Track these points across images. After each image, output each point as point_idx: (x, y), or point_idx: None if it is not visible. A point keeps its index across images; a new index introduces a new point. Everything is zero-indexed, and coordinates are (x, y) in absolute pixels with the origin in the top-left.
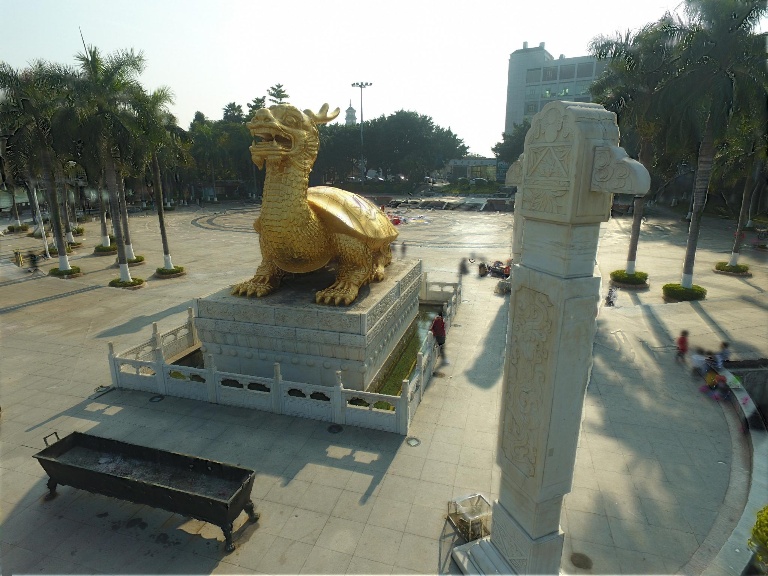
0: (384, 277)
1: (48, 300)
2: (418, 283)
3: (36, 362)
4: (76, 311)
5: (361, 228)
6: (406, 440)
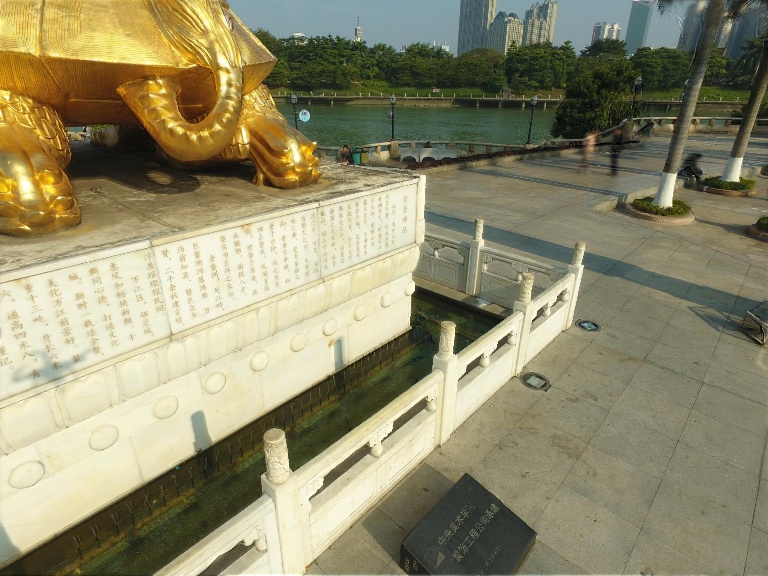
0: None
1: (542, 182)
2: None
3: None
4: (480, 190)
5: None
6: None
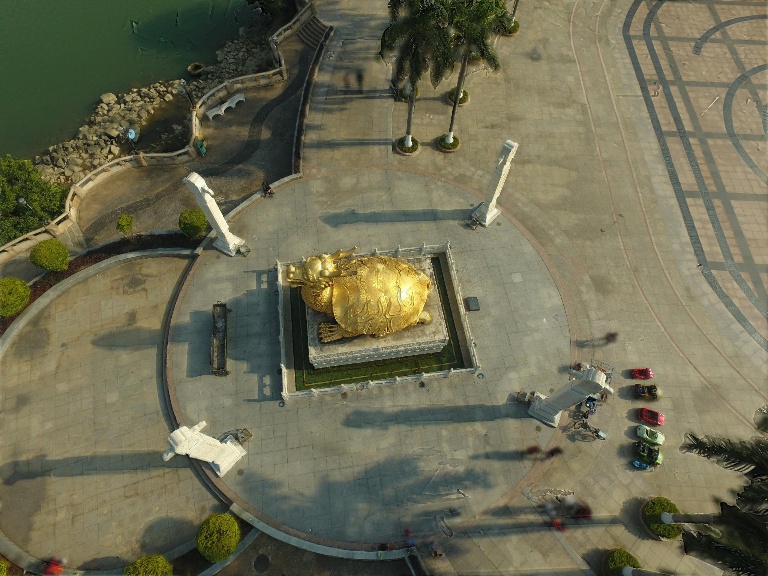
0: (385, 335)
1: (354, 144)
2: (433, 346)
3: (287, 221)
4: (345, 174)
5: (346, 324)
6: (282, 401)
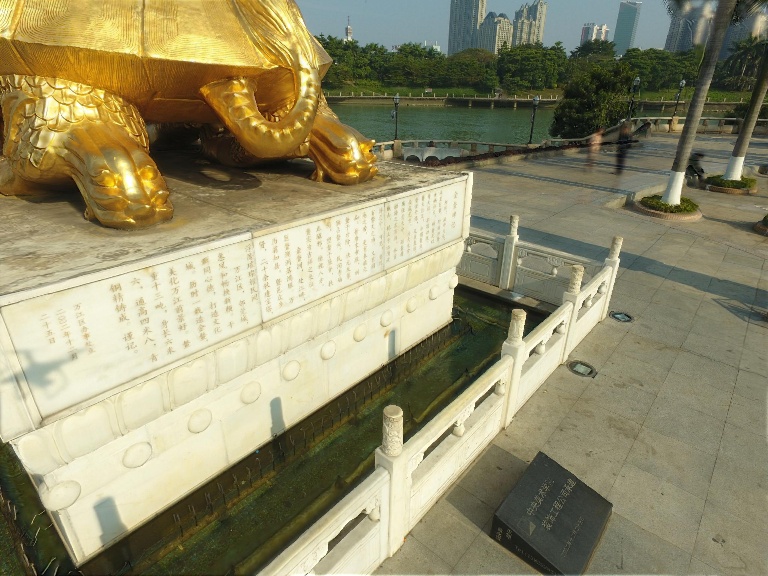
0: None
1: (550, 181)
2: None
3: None
4: (491, 188)
5: None
6: None
